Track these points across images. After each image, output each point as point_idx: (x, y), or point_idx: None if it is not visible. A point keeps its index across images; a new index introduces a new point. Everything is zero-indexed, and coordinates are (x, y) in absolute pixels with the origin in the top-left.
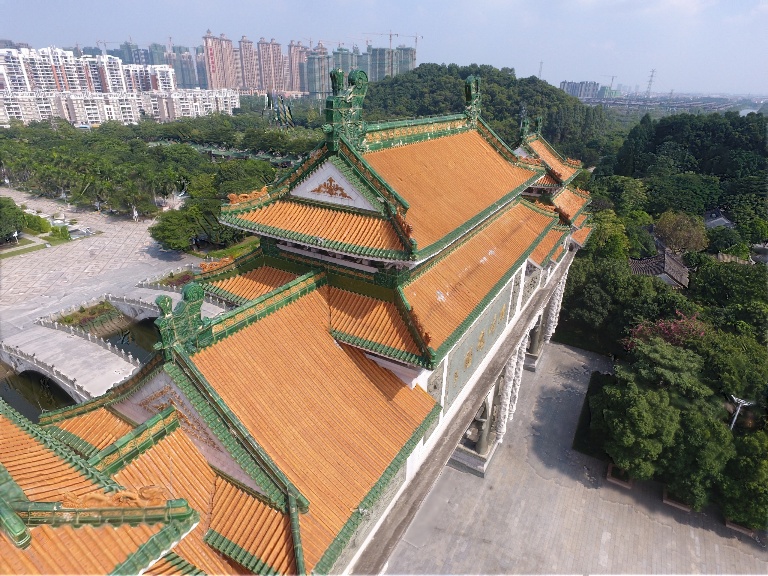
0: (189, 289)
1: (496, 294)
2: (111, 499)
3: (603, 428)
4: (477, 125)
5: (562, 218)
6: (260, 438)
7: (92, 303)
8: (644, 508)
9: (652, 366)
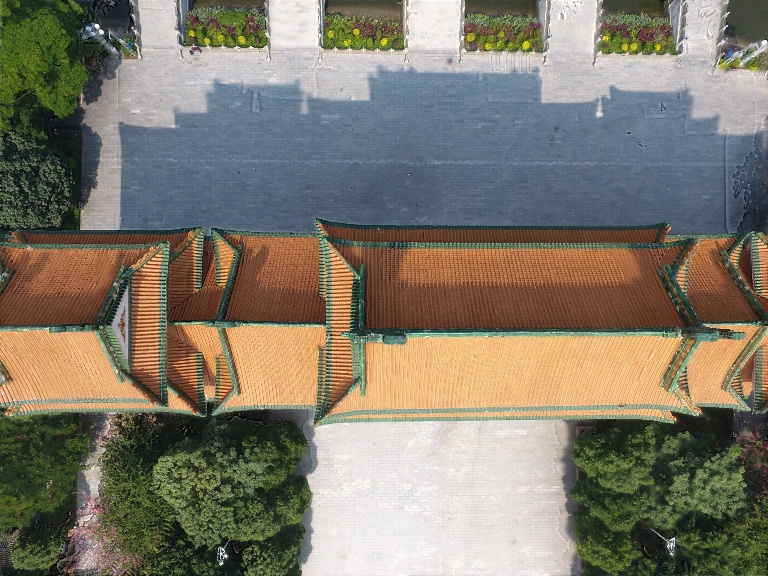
0: (223, 327)
1: None
2: None
3: (616, 423)
4: None
5: None
6: (242, 364)
7: None
8: (562, 455)
9: (694, 469)
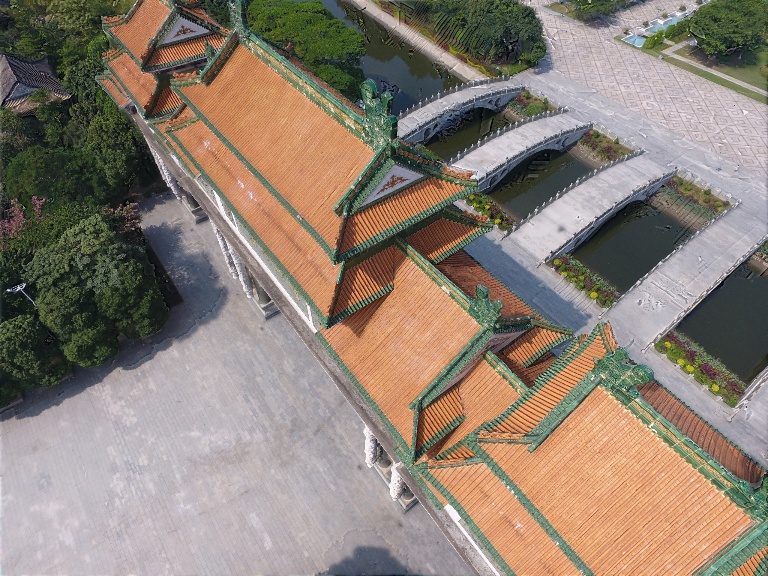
0: None
1: None
2: (145, 53)
3: None
4: None
5: None
6: None
7: (723, 196)
8: None
9: None
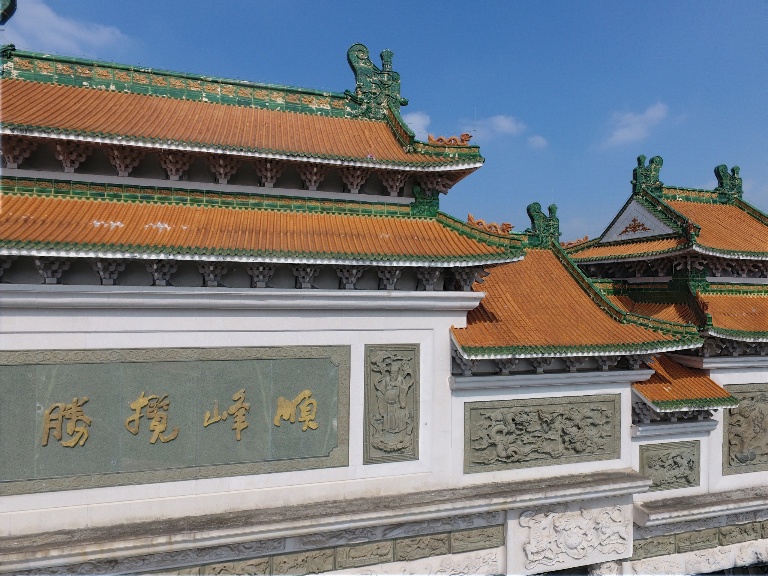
0: None
1: (5, 249)
2: None
3: None
4: (388, 115)
5: (698, 314)
6: None
7: None
8: None
9: None
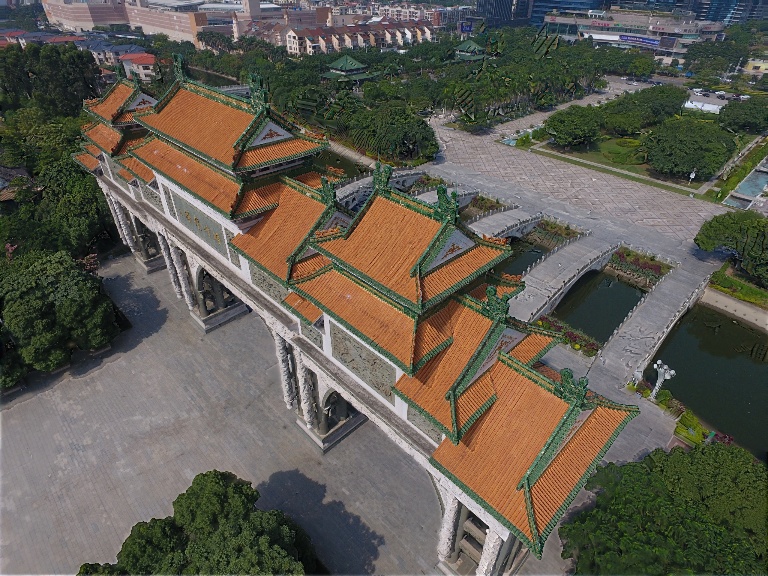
0: None
1: None
2: None
3: None
4: None
5: None
6: None
7: (579, 229)
8: None
9: None
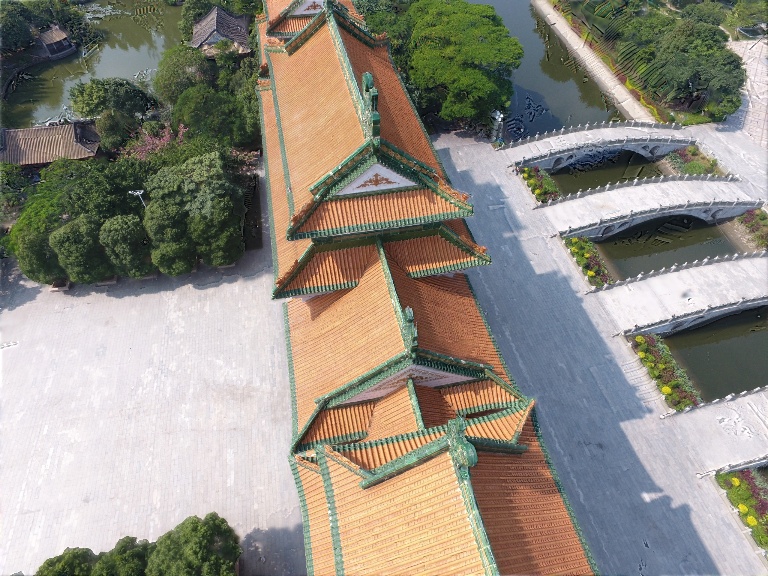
0: None
1: None
2: None
3: None
4: None
5: None
6: None
7: None
8: None
9: None
